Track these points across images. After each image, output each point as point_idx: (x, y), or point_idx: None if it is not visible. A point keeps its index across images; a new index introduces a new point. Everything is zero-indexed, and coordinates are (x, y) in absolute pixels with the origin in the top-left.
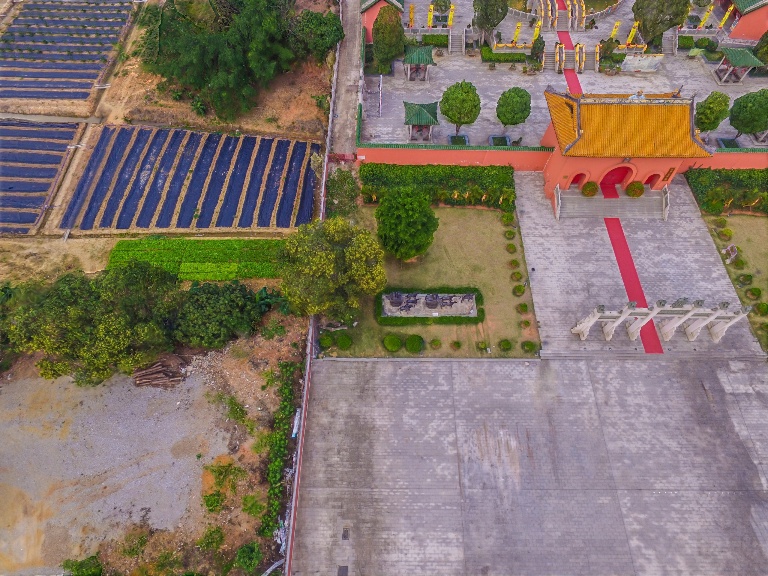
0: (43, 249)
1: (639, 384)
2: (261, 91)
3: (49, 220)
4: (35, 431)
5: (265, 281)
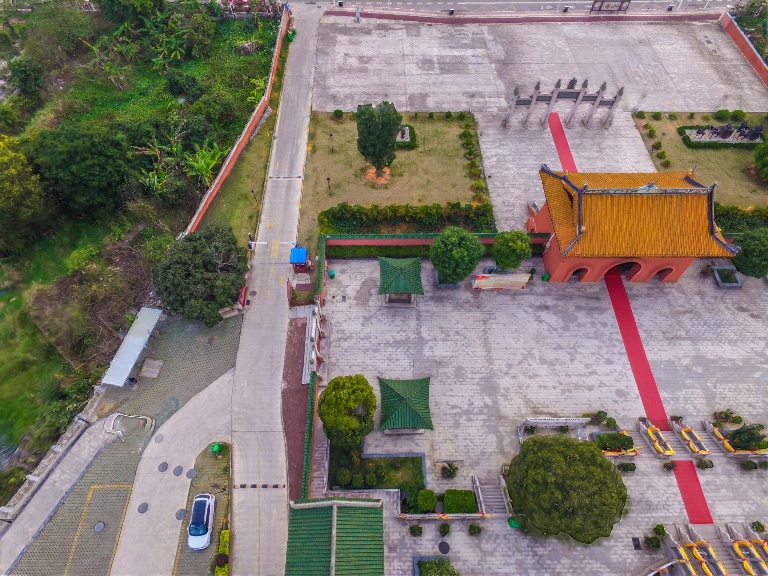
0: None
1: (561, 101)
2: None
3: None
4: None
5: None
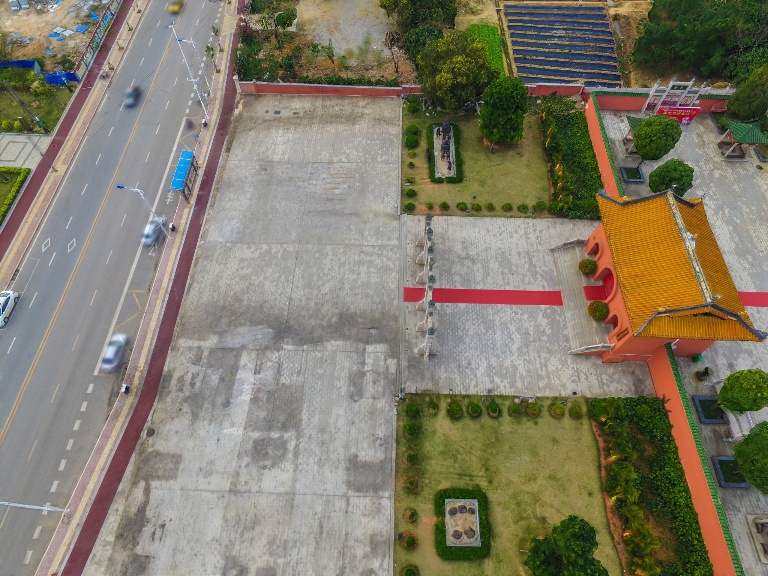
0: (486, 2)
1: (377, 278)
2: (677, 73)
3: (510, 1)
4: (364, 7)
5: None
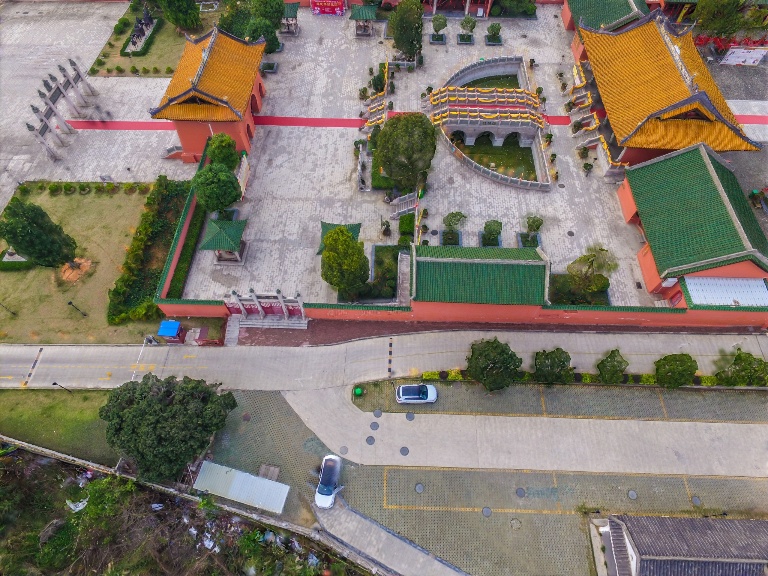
0: None
1: None
2: None
3: None
4: None
5: None
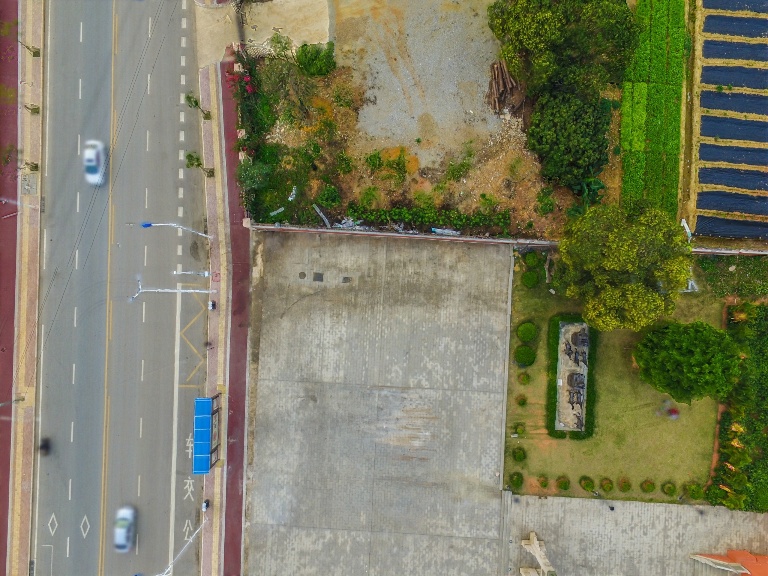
0: None
1: None
2: None
3: None
4: None
5: (617, 185)
